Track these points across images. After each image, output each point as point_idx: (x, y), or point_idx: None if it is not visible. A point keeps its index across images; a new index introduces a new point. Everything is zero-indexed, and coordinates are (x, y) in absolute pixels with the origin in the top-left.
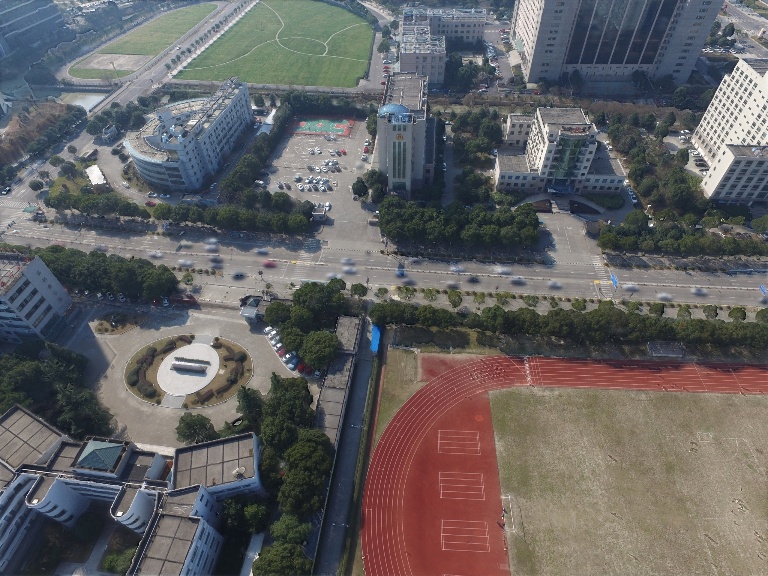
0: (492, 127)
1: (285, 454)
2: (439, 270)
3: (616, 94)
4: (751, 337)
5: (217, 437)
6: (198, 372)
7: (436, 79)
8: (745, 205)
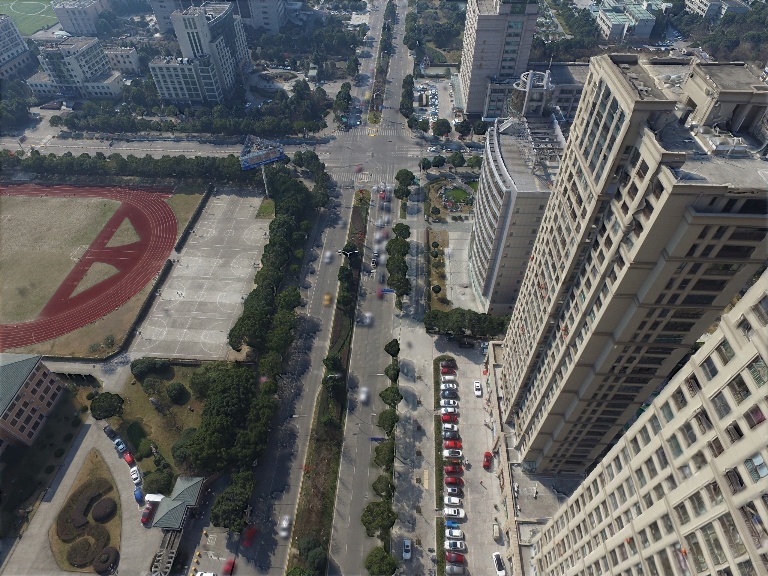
0: None
1: None
2: None
3: None
4: (60, 164)
5: None
6: None
7: (90, 29)
8: (189, 104)
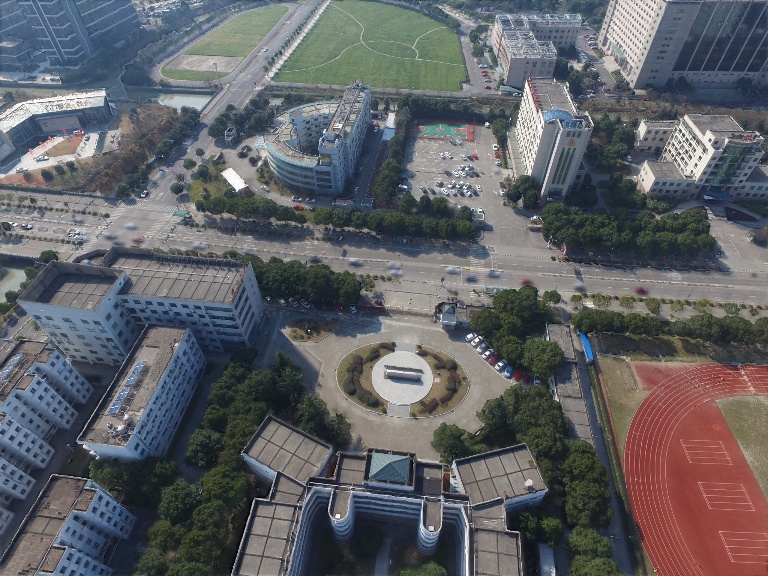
0: (628, 133)
1: (565, 465)
2: (618, 277)
3: (725, 101)
4: None
5: (467, 448)
6: (414, 381)
7: None
8: None
